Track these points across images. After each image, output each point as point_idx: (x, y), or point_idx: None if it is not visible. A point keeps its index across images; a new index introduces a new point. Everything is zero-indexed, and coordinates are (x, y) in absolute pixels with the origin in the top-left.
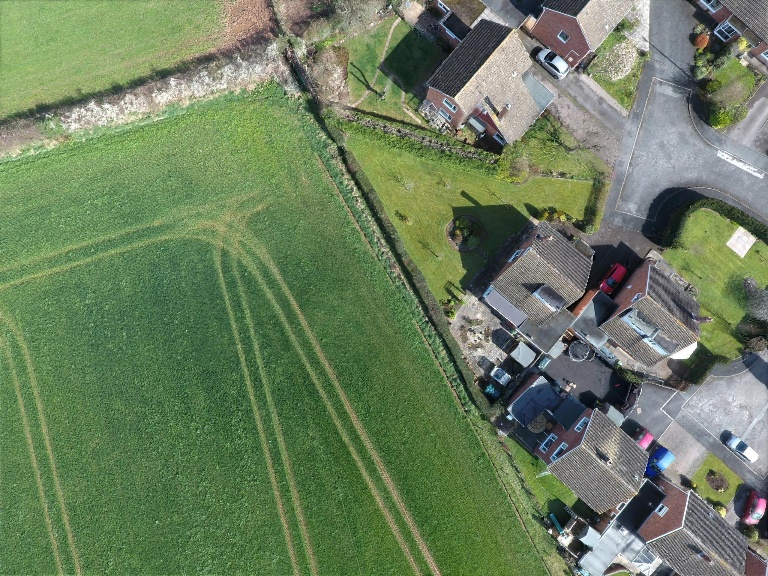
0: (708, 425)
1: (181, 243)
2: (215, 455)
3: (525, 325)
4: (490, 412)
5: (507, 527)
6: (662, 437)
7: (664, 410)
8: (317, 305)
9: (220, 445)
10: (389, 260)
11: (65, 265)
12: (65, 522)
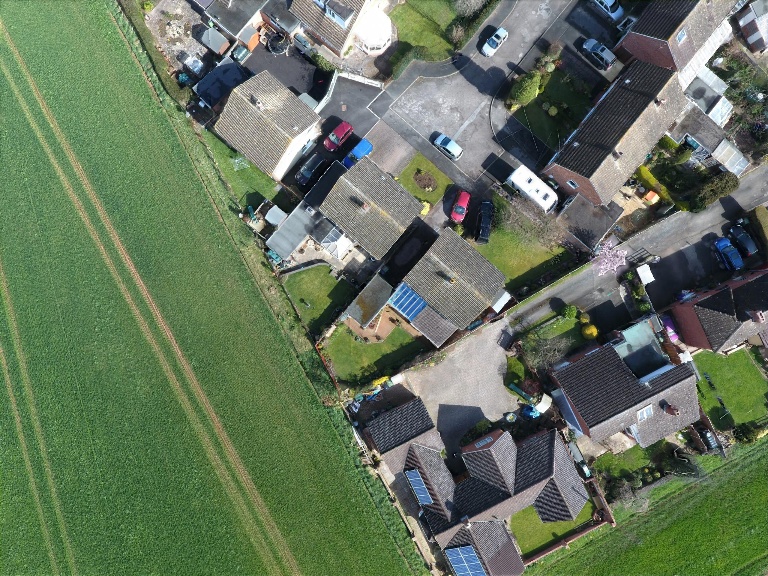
0: (417, 126)
1: None
2: None
3: (213, 7)
4: (179, 96)
5: (203, 217)
6: (368, 135)
7: (370, 108)
8: None
9: None
10: None
11: None
12: None
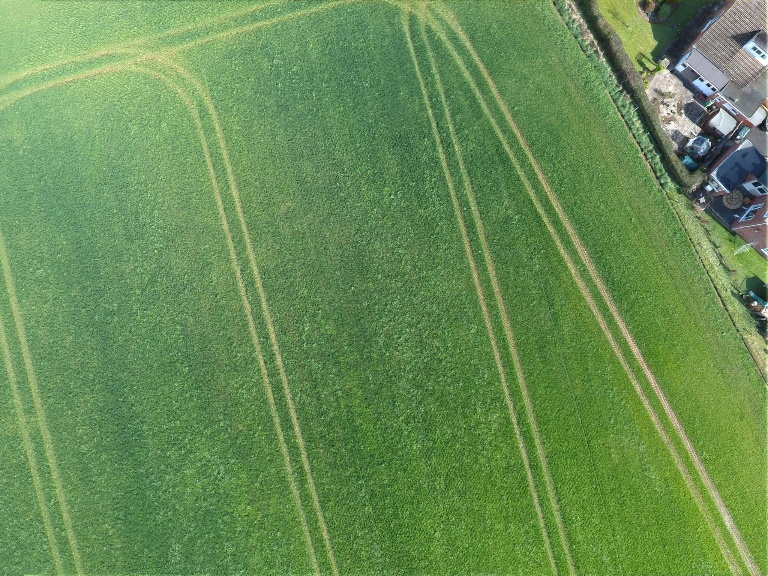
0: None
1: (368, 5)
2: (409, 221)
3: (728, 88)
4: (691, 180)
5: (706, 304)
6: None
7: None
8: (508, 72)
9: (414, 211)
10: (580, 27)
11: (251, 24)
12: (259, 286)
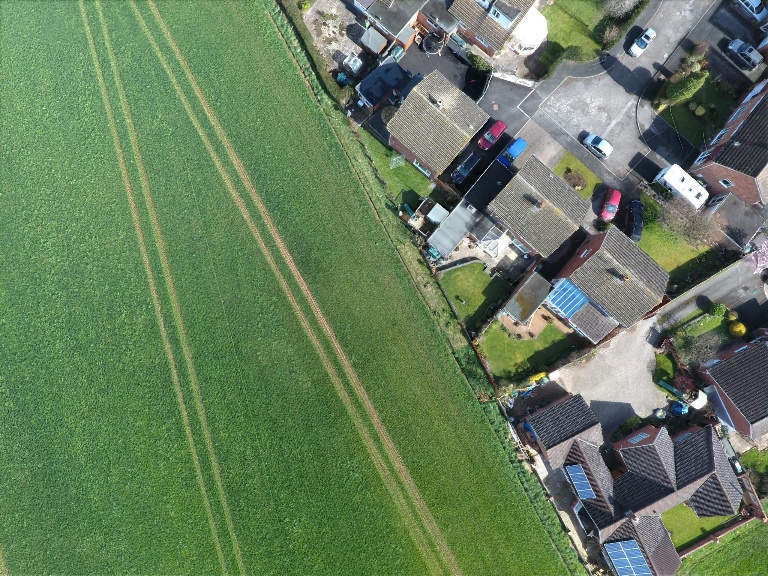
0: (566, 125)
1: None
2: (61, 131)
3: (374, 7)
4: (340, 95)
5: (360, 215)
6: (519, 134)
7: (521, 108)
8: None
9: (66, 122)
10: None
11: None
12: None
